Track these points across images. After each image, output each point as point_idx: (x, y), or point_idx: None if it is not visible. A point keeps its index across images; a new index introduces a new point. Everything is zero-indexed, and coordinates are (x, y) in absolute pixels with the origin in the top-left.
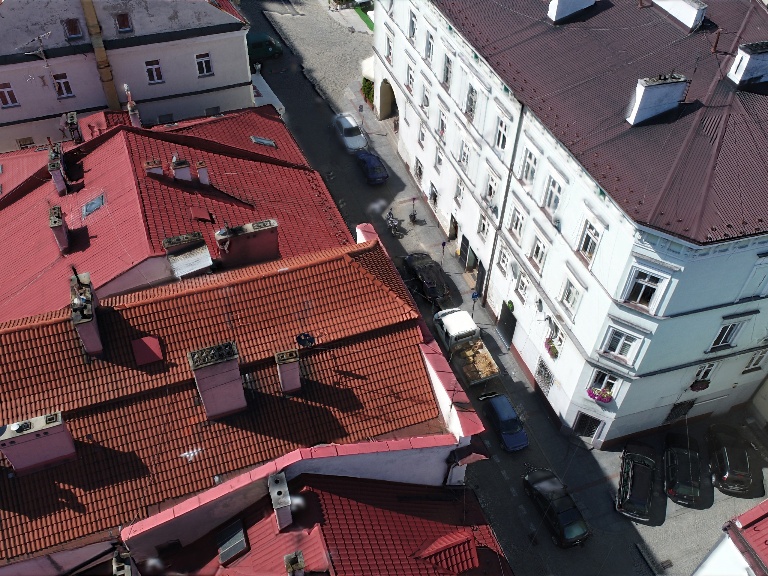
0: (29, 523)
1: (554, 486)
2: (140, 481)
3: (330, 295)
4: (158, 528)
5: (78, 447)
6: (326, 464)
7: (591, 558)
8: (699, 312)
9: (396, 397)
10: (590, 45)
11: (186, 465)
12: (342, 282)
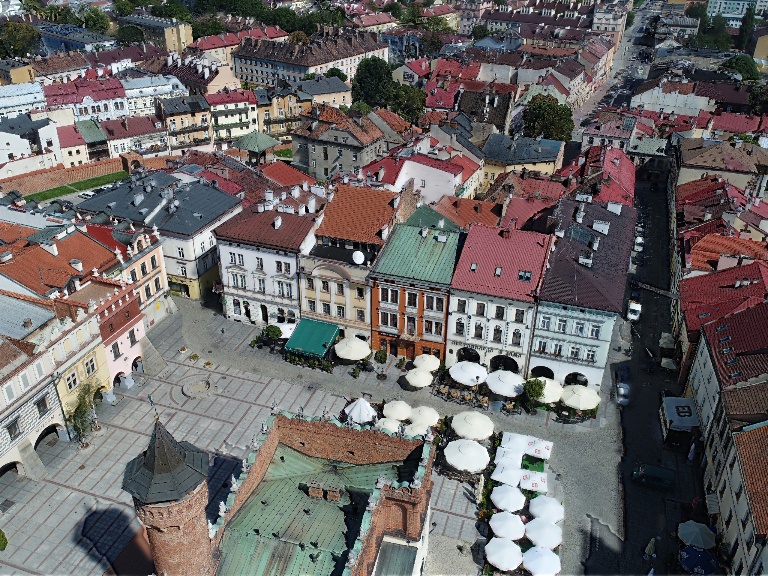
0: None
1: None
2: None
3: None
4: None
5: None
6: None
7: None
8: None
9: None
10: None
11: None
12: None
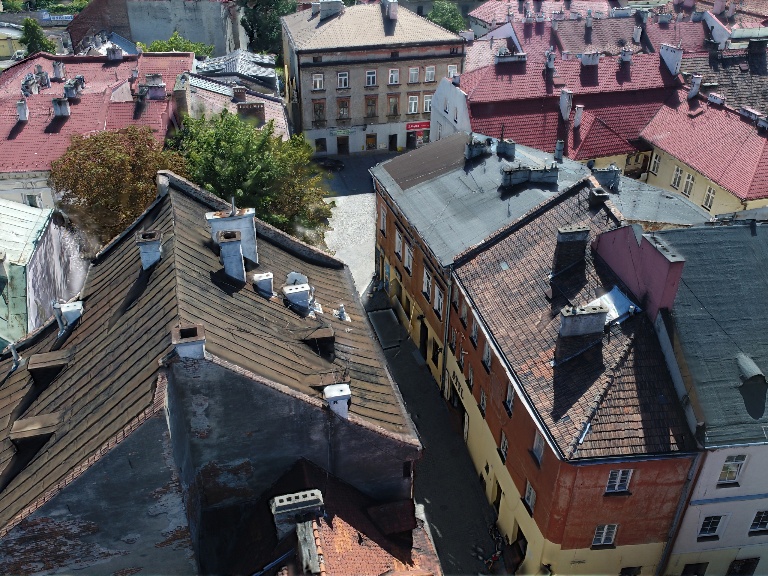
0: None
1: None
2: None
3: (760, 4)
4: None
5: (693, 6)
6: None
7: None
8: None
9: None
10: None
11: None
12: (766, 2)
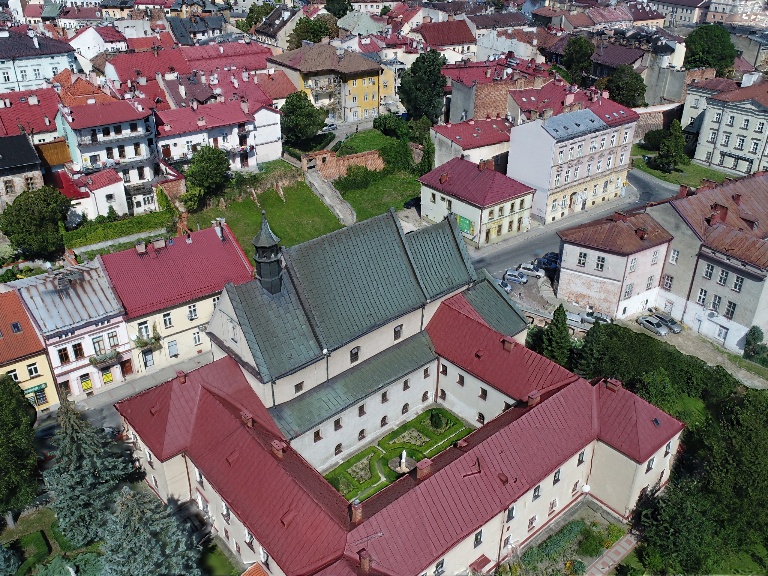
0: None
1: None
2: None
3: None
4: (119, 94)
5: None
6: None
7: None
8: None
9: None
10: (2, 47)
11: None
12: None
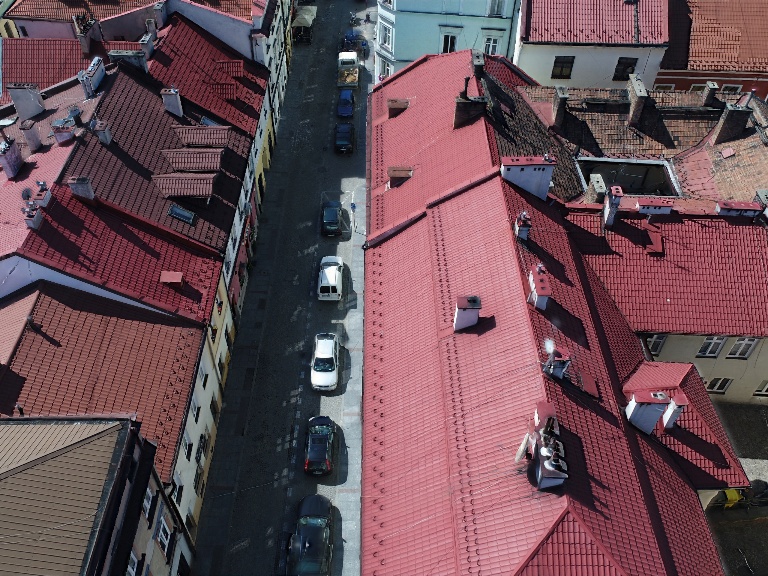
0: (68, 9)
1: (346, 125)
2: (115, 7)
3: None
4: (114, 21)
5: None
6: (187, 9)
7: (349, 161)
8: (418, 13)
9: (238, 6)
10: None
11: (136, 7)
12: None
